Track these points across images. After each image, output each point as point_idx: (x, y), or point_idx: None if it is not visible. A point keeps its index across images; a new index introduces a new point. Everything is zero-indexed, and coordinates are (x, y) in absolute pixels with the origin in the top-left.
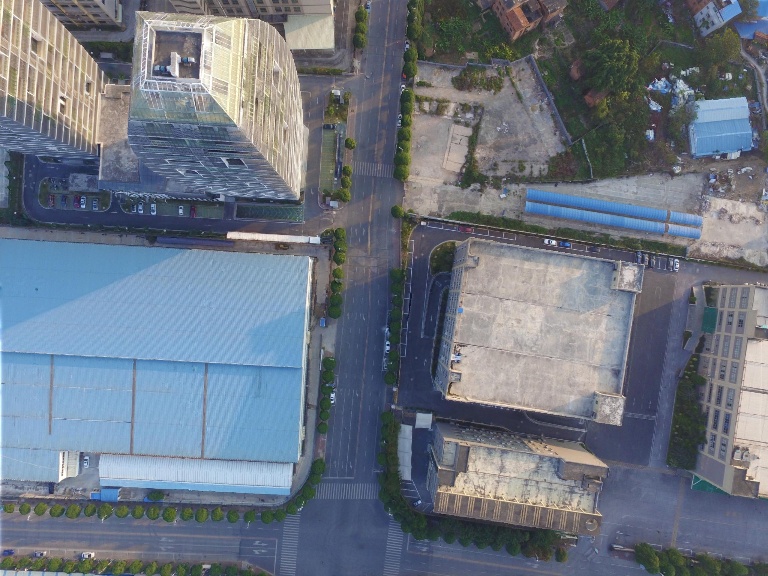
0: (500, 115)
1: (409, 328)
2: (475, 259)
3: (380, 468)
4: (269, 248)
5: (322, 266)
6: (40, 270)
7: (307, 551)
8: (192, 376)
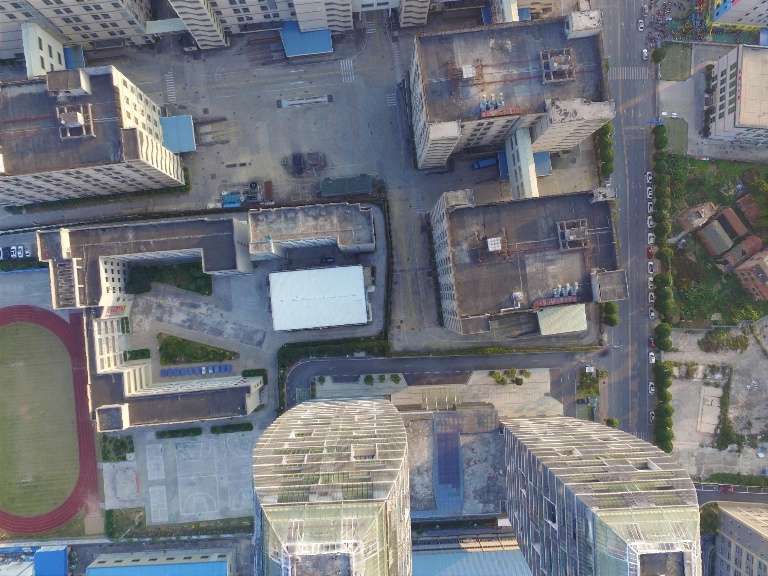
0: (748, 373)
1: None
2: None
3: None
4: None
5: None
6: None
7: None
8: None
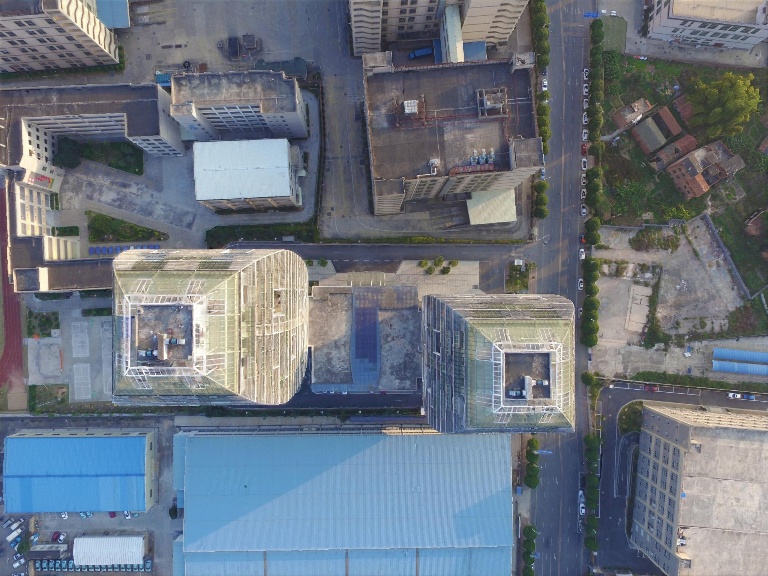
0: (678, 273)
1: (602, 489)
2: (697, 446)
3: None
4: None
5: None
6: (247, 466)
7: None
8: (404, 561)
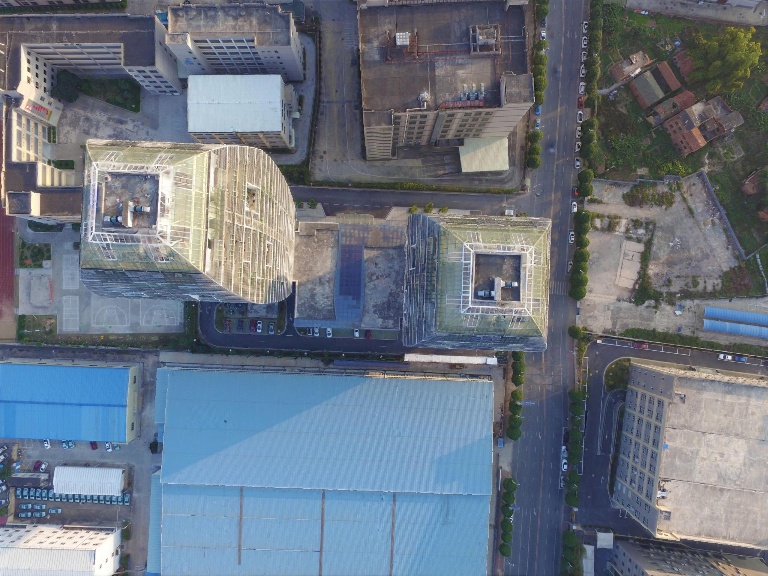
0: (672, 230)
1: (585, 446)
2: (681, 397)
3: None
4: (443, 367)
5: (496, 384)
6: (228, 402)
7: None
8: (380, 505)
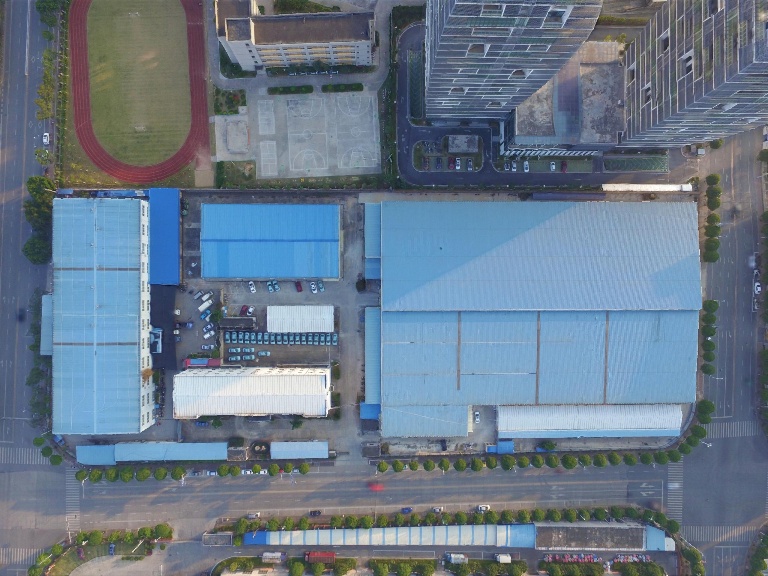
0: None
1: None
2: None
3: (756, 405)
4: (636, 199)
5: None
6: (442, 229)
7: (691, 490)
8: (594, 324)
